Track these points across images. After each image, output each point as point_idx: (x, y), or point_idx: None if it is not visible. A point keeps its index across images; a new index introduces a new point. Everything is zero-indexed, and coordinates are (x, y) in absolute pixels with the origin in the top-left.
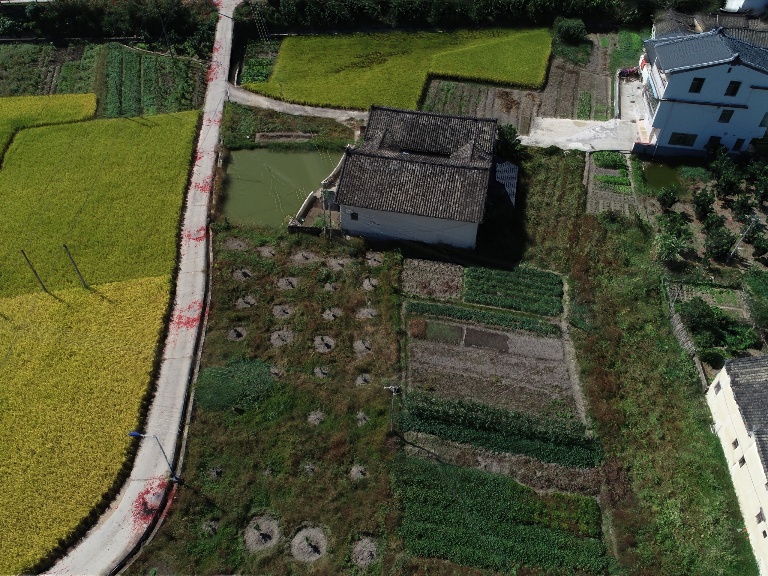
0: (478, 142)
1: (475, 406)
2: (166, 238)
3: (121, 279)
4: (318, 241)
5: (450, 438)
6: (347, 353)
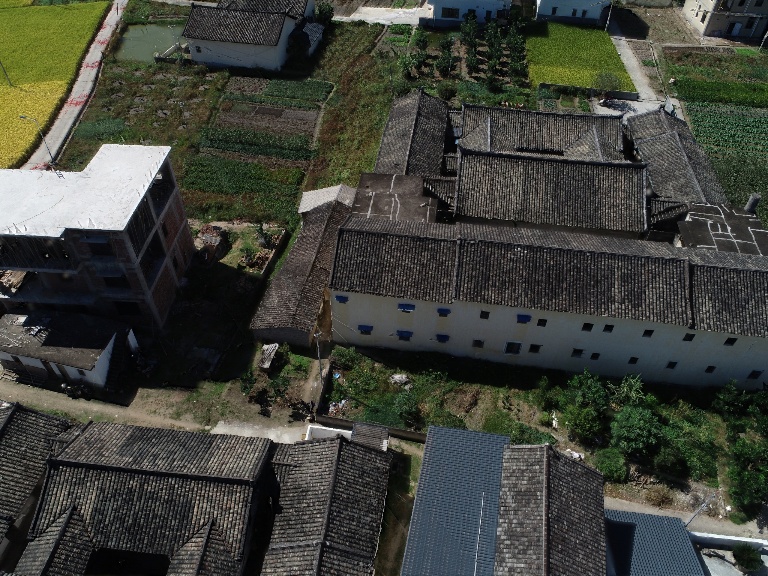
0: (294, 8)
1: (244, 132)
2: (70, 64)
3: (35, 82)
4: (174, 67)
5: (227, 149)
6: (176, 117)
